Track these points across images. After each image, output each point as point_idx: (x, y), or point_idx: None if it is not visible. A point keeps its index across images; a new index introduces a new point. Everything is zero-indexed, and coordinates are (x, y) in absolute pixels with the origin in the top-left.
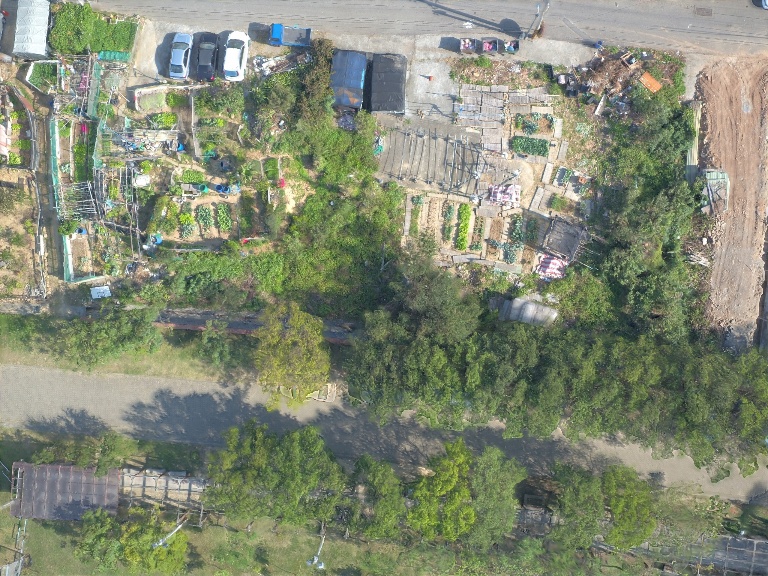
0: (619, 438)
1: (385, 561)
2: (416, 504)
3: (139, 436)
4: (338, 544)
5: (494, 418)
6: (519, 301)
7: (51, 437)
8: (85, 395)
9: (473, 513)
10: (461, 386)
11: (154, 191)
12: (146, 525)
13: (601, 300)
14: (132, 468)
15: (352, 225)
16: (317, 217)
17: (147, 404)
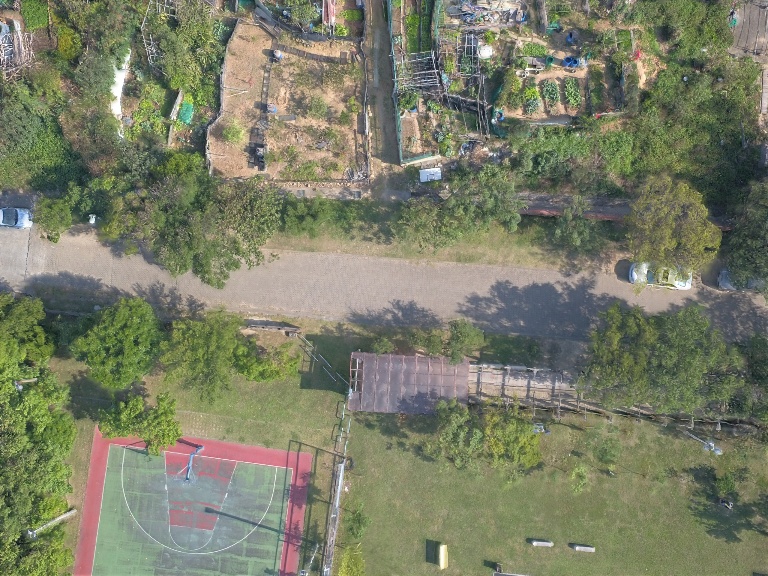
0: None
1: None
2: None
3: None
4: (691, 443)
5: None
6: None
7: (376, 330)
8: (413, 285)
9: None
10: None
11: (501, 62)
12: (510, 415)
13: None
14: None
15: (707, 102)
16: (671, 93)
17: (482, 294)
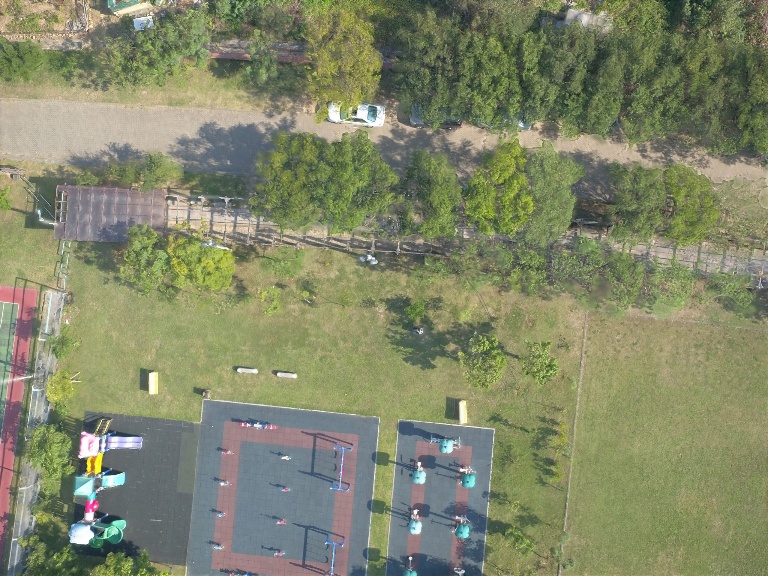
0: (675, 159)
1: (435, 290)
2: (473, 195)
3: (183, 168)
4: (387, 273)
5: (551, 119)
6: (574, 12)
7: (94, 172)
8: (128, 128)
9: (531, 204)
10: (519, 74)
11: None
12: (194, 238)
13: (656, 17)
14: (176, 200)
15: None
16: None
17: (191, 136)
